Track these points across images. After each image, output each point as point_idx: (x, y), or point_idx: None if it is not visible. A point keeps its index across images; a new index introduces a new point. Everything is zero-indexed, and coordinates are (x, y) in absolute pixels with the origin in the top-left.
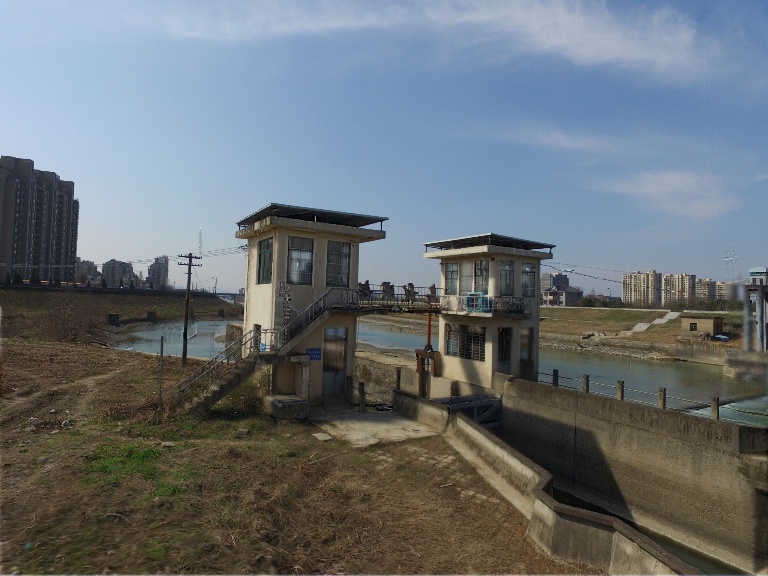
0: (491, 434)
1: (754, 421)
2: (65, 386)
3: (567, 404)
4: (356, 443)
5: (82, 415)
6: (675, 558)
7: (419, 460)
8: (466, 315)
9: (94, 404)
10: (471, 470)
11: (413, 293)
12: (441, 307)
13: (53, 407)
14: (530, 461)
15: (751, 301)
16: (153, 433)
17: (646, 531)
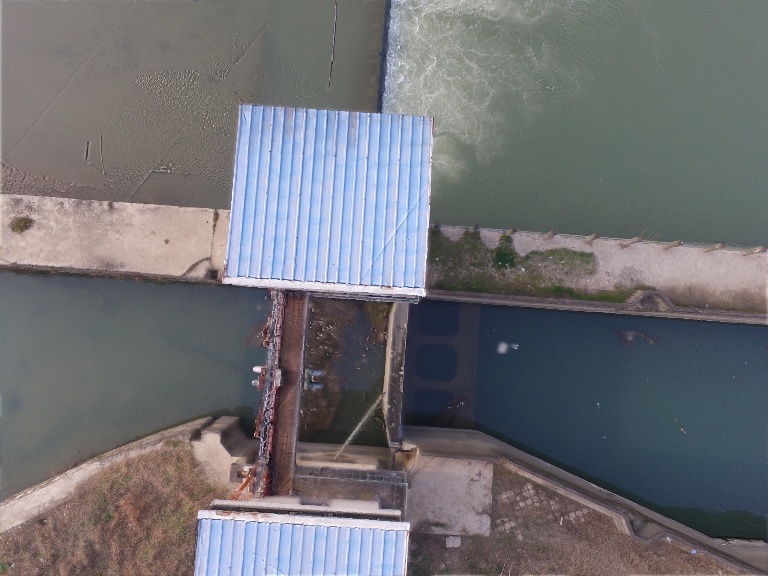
0: (566, 488)
1: (548, 75)
2: None
3: None
4: (484, 532)
5: None
6: (692, 545)
7: (523, 508)
8: None
9: None
10: (554, 494)
11: (272, 327)
12: None
13: None
14: (609, 508)
15: (619, 8)
16: None
17: (535, 308)
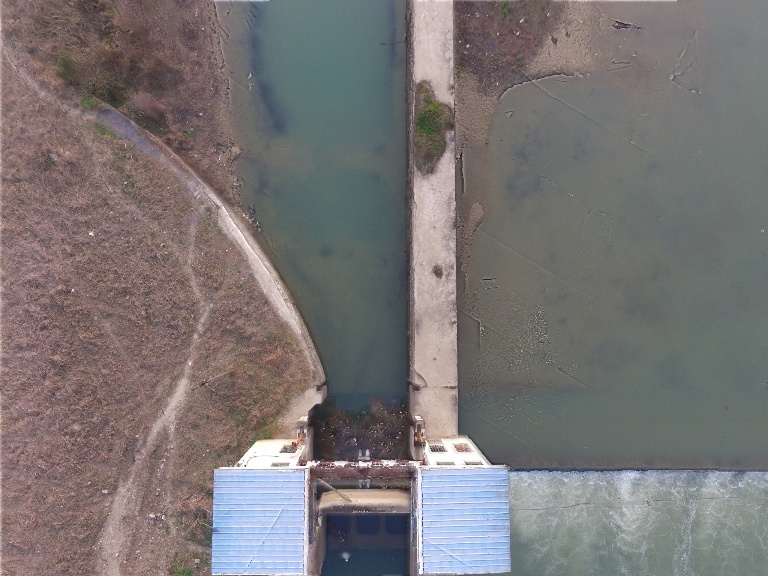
0: None
1: None
2: (160, 425)
3: (415, 571)
4: None
5: (169, 503)
6: None
7: None
8: (410, 511)
9: (174, 484)
10: None
11: None
12: (412, 479)
13: (157, 486)
14: None
15: None
16: (195, 539)
17: None
